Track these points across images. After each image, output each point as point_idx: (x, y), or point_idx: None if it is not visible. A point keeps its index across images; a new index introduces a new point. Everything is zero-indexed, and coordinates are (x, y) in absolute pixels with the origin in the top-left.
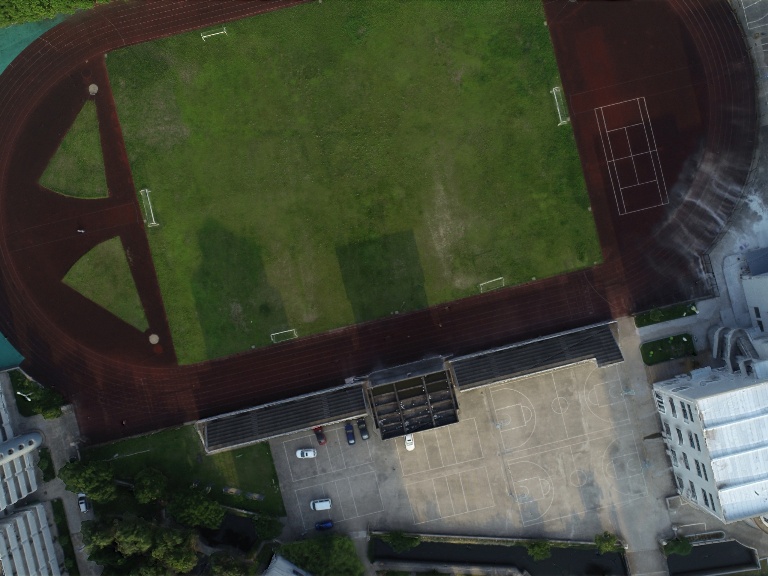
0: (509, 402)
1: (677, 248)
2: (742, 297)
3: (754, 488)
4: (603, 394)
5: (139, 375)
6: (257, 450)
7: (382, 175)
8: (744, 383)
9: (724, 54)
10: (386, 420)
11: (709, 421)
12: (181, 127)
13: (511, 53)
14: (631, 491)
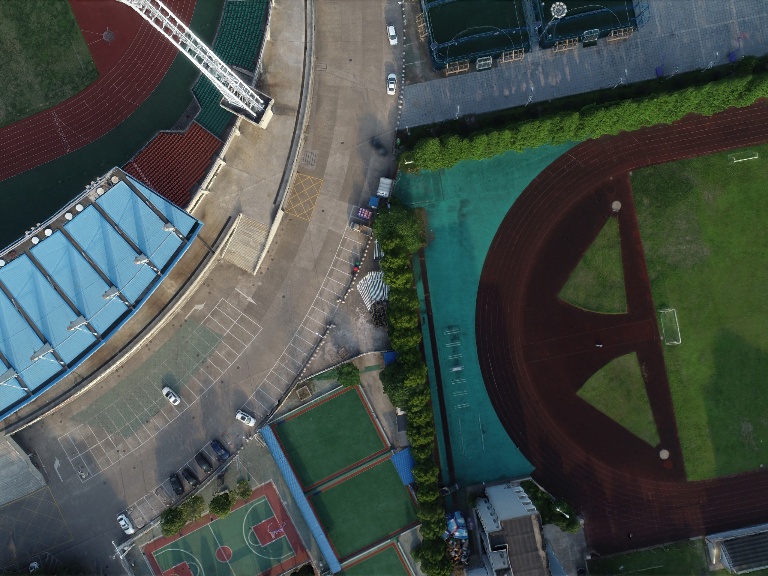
0: None
1: None
2: None
3: None
4: None
5: (648, 489)
6: None
7: None
8: None
9: None
10: None
11: None
12: (702, 247)
13: None
14: None
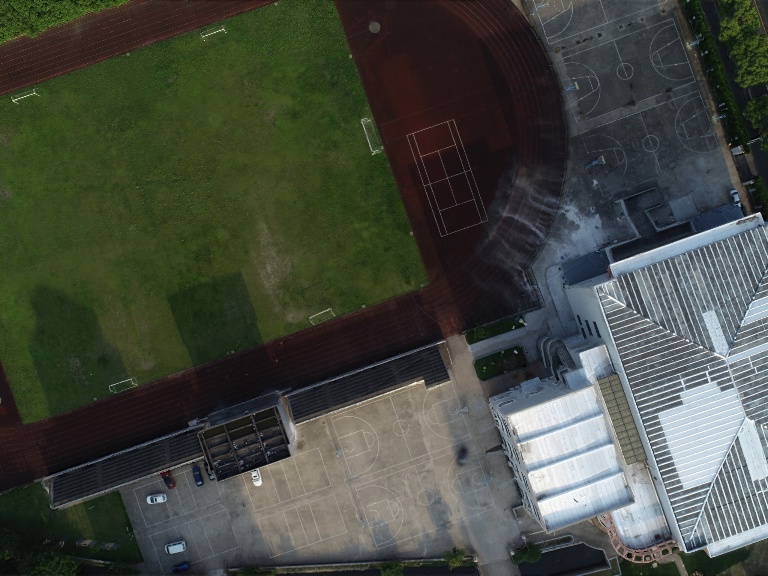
0: (351, 429)
1: (500, 264)
2: (567, 306)
3: (573, 496)
4: (442, 413)
5: None
6: (109, 500)
7: (205, 219)
8: (555, 394)
9: (527, 71)
10: (221, 461)
11: (523, 435)
12: (3, 190)
13: (320, 88)
14: (478, 505)
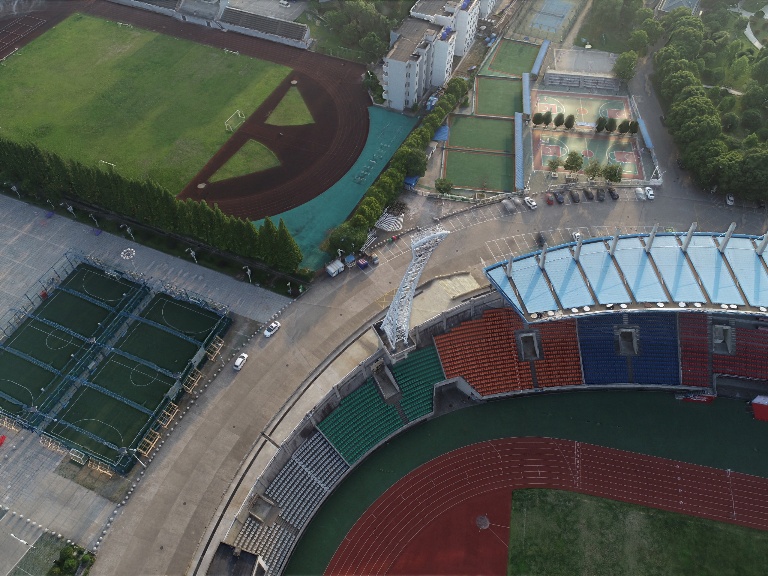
0: None
1: (43, 3)
2: None
3: None
4: None
5: (316, 75)
6: None
7: None
8: None
9: None
10: None
11: None
12: (178, 145)
13: None
14: None
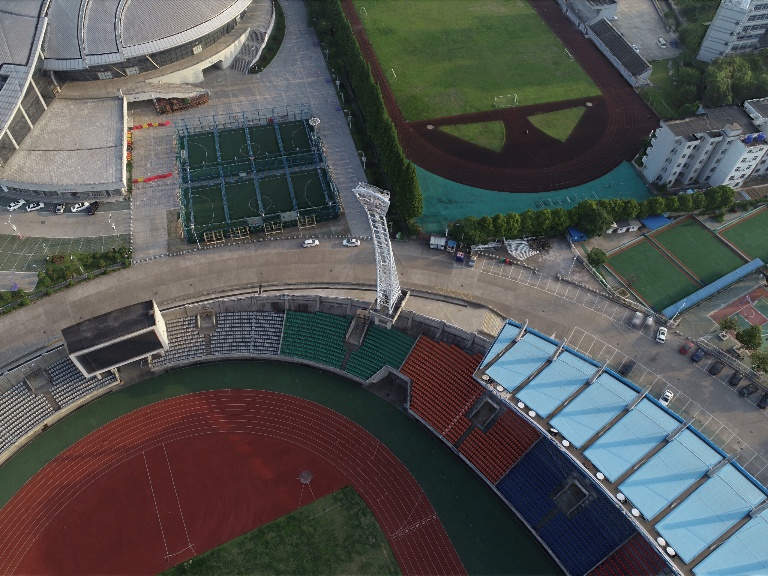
0: None
1: None
2: None
3: None
4: None
5: (615, 110)
6: None
7: (468, 25)
8: None
9: None
10: None
11: None
12: (451, 92)
13: None
14: None
